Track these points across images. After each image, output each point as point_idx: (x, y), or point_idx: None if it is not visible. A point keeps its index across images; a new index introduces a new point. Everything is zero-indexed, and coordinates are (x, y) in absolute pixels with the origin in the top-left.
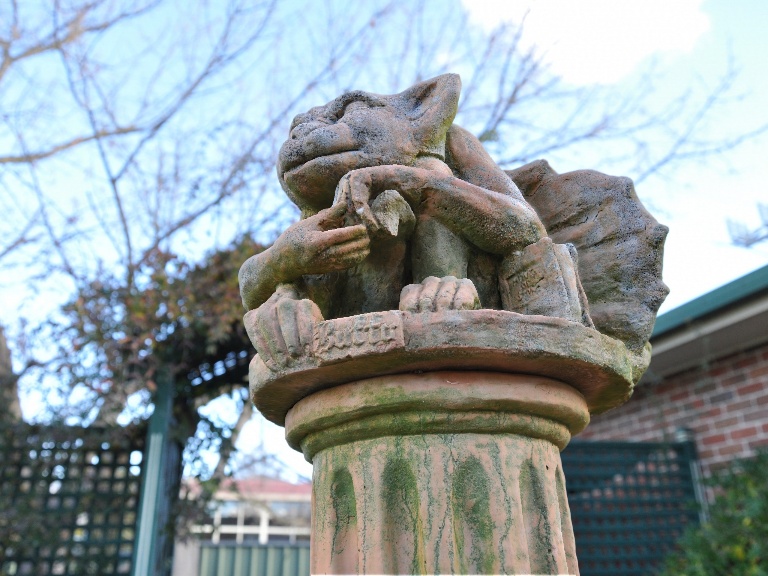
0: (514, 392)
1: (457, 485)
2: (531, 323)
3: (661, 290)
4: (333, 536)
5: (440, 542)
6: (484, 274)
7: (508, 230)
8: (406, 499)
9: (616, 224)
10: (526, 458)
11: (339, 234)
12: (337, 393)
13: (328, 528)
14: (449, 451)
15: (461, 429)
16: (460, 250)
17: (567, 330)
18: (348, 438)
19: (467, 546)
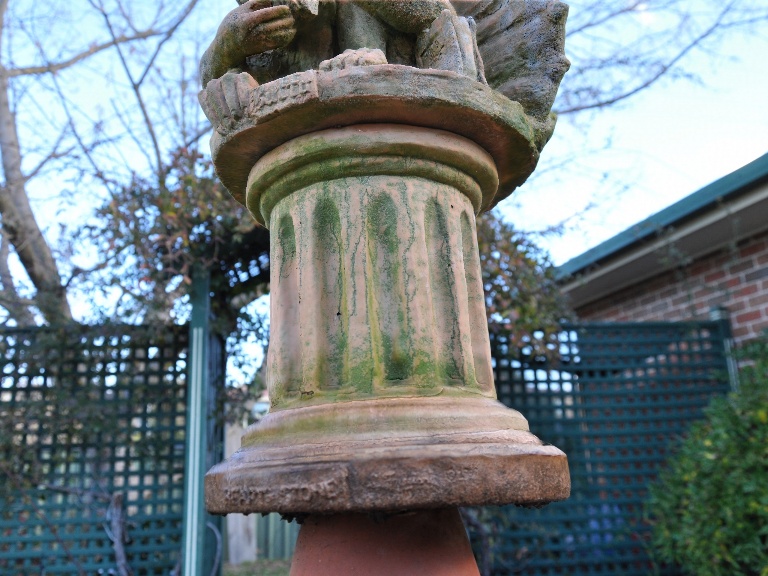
0: (416, 138)
1: (372, 215)
2: (423, 74)
3: (561, 62)
4: (281, 266)
5: (356, 253)
6: (402, 54)
7: (416, 8)
8: (334, 230)
9: (523, 6)
10: (431, 196)
11: (265, 12)
12: (276, 151)
13: (277, 260)
14: (365, 188)
15: (374, 171)
16: (377, 30)
17: (456, 81)
18: (289, 189)
19: (380, 260)
